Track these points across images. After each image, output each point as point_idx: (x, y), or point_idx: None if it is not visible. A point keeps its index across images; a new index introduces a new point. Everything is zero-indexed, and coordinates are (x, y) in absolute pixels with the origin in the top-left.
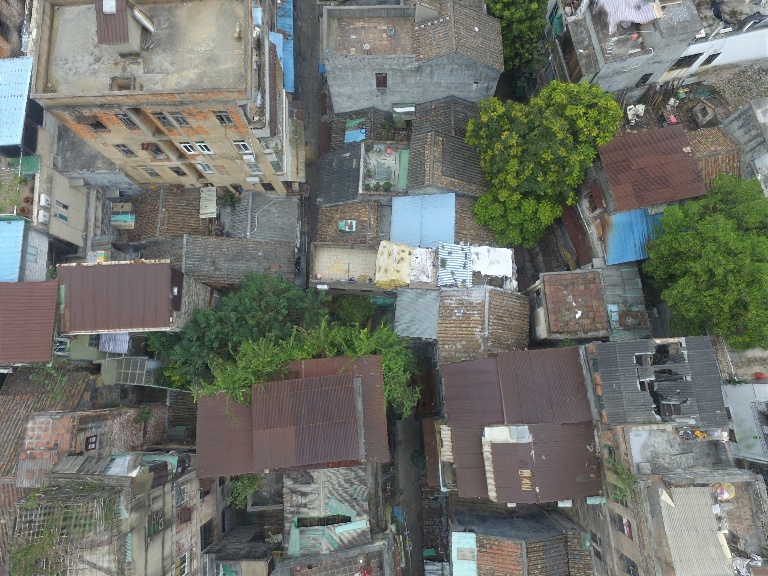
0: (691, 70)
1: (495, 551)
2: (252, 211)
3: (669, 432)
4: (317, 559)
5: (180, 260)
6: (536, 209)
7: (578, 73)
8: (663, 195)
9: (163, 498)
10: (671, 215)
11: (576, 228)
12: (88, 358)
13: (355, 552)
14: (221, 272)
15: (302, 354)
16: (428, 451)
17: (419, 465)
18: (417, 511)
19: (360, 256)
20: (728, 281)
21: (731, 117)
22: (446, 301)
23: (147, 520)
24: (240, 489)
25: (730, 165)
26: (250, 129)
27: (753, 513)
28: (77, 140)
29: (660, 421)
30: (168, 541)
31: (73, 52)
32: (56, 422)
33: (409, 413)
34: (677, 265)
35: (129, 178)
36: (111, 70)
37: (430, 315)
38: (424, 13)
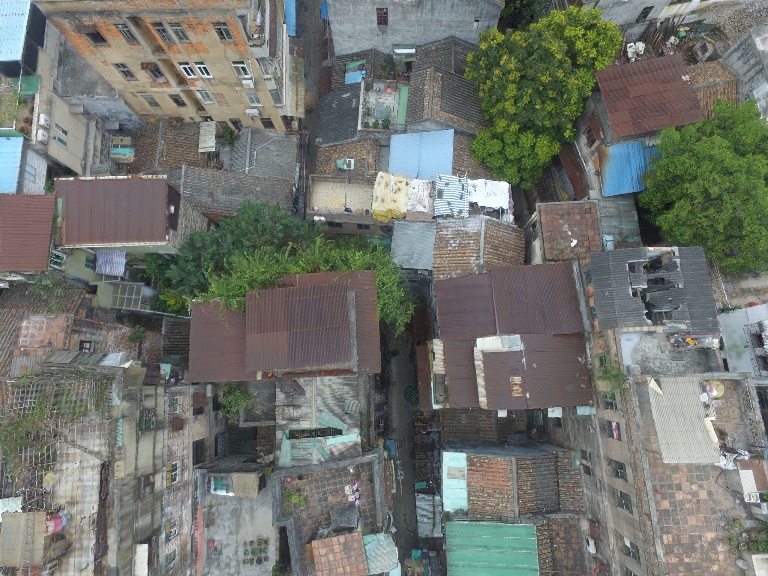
0: (692, 6)
1: (485, 469)
2: (251, 147)
3: (660, 339)
4: (308, 469)
5: (178, 190)
6: (534, 144)
7: (578, 3)
8: (660, 122)
9: (155, 399)
10: (668, 137)
11: (574, 166)
12: (84, 278)
13: (345, 463)
14: (219, 204)
15: (297, 269)
16: (421, 377)
17: (412, 398)
18: (410, 450)
19: (357, 190)
20: (723, 201)
21: (730, 49)
22: (442, 232)
23: (139, 413)
24: (232, 402)
25: (728, 97)
26: (249, 47)
27: (742, 413)
28: (77, 67)
29: (651, 325)
30: (159, 442)
31: None
32: (50, 322)
33: None
34: (673, 190)
35: (129, 107)
36: None
37: (426, 247)
38: None
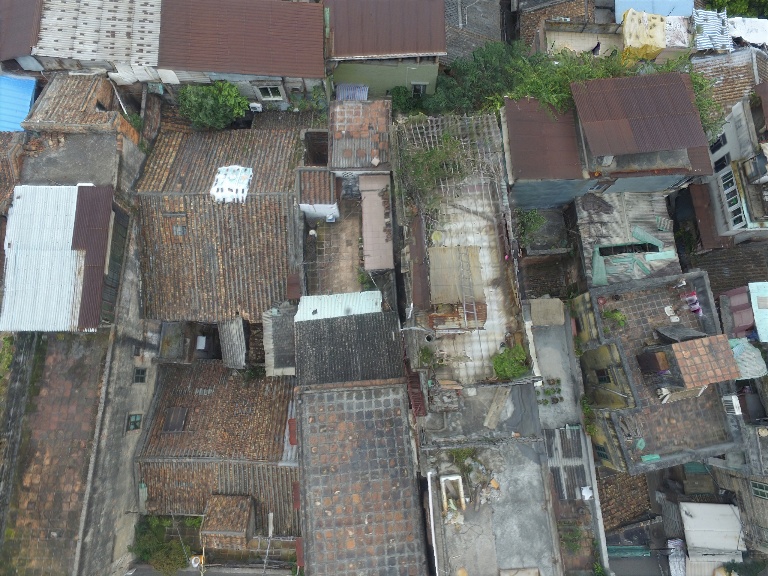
0: None
1: None
2: (461, 5)
3: None
4: (631, 284)
5: None
6: None
7: None
8: None
9: None
10: None
11: None
12: None
13: (673, 277)
14: None
15: None
16: (700, 214)
17: None
18: None
19: (590, 40)
20: None
21: None
22: (699, 72)
23: None
24: (532, 219)
25: None
26: None
27: None
28: None
29: None
30: None
31: None
32: (367, 107)
33: (715, 141)
34: None
35: None
36: None
37: None
38: None
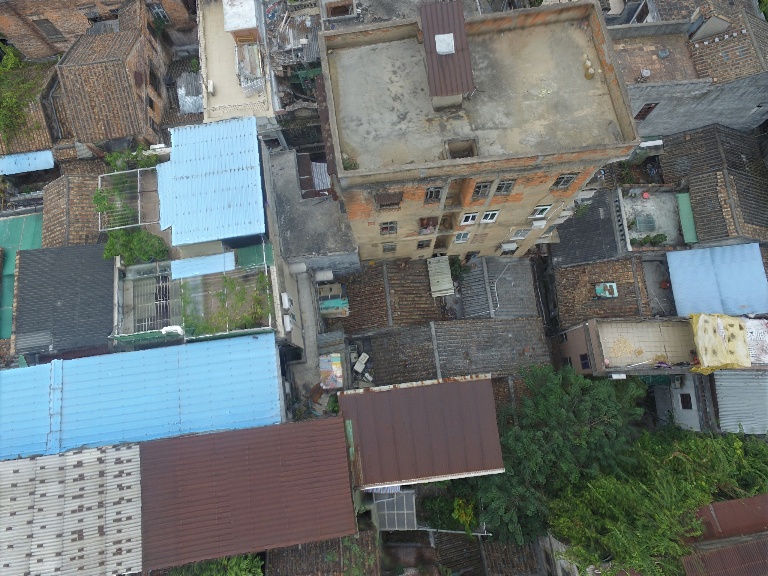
0: None
1: None
2: (489, 282)
3: None
4: None
5: (430, 356)
6: None
7: None
8: None
9: None
10: None
11: None
12: (359, 506)
13: None
14: (477, 365)
15: (702, 494)
16: None
17: None
18: None
19: (650, 331)
20: None
21: None
22: None
23: None
24: None
25: None
26: (580, 191)
27: None
28: (296, 215)
29: None
30: None
31: (366, 109)
32: None
33: None
34: None
35: (358, 257)
36: (425, 129)
37: None
38: (712, 27)
